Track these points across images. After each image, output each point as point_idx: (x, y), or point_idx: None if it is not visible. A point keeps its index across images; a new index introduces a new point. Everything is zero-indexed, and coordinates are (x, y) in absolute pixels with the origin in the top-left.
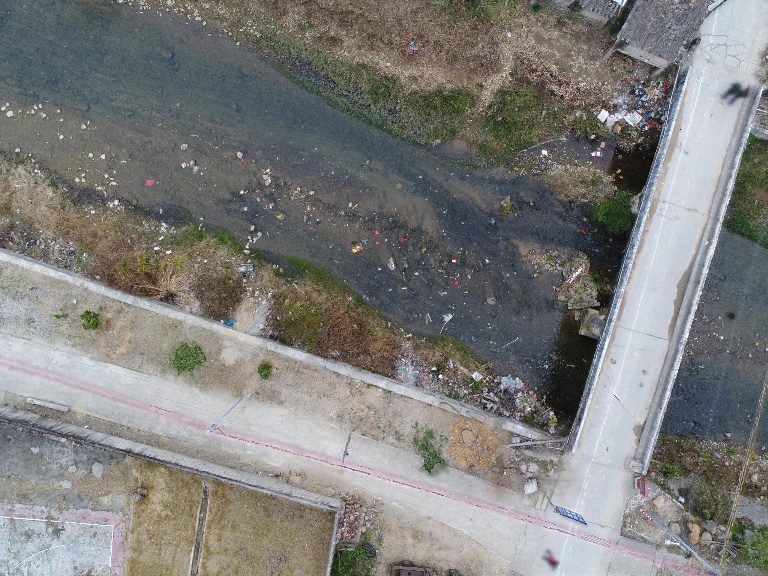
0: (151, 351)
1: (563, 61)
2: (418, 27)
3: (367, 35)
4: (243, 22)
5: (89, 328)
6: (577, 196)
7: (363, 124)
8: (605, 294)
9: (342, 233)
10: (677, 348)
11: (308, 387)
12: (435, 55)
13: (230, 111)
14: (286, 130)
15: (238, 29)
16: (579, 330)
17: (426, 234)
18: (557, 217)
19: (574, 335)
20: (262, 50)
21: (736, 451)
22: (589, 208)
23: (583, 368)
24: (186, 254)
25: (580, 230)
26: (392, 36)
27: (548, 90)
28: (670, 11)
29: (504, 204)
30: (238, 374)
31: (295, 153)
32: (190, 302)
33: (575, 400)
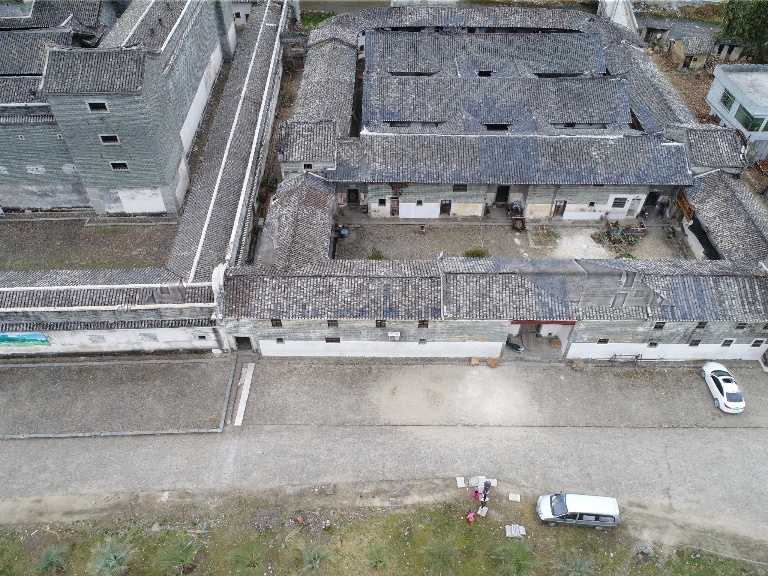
0: None
1: None
2: None
3: None
4: None
5: None
6: None
7: None
8: None
9: None
10: None
11: None
12: None
13: None
14: None
15: None
16: None
17: None
18: None
19: None
20: None
21: (553, 4)
22: None
23: None
24: None
25: None
26: None
27: None
28: None
29: None
30: None
31: None
32: None
33: None
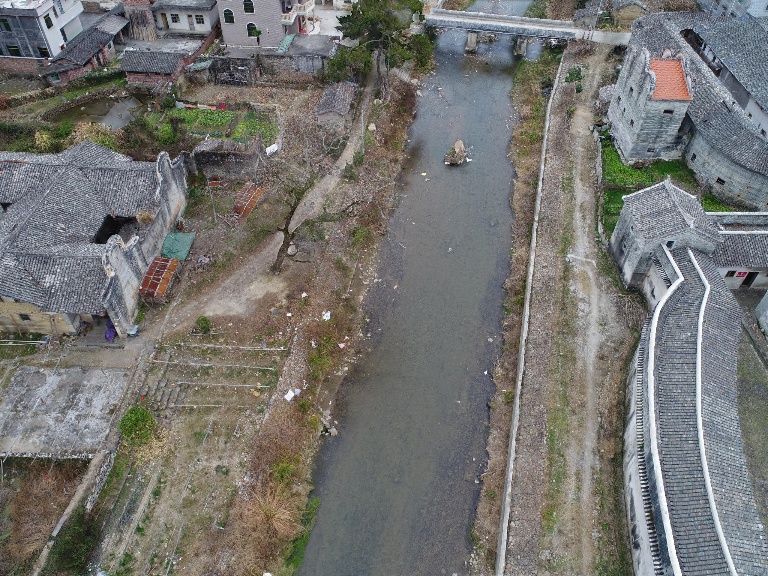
0: None
1: None
2: None
3: None
4: None
5: None
6: None
7: None
8: None
9: (488, 6)
10: None
11: None
12: None
13: None
14: None
15: None
16: None
17: None
18: None
19: None
20: None
21: (432, 65)
22: None
23: None
24: None
25: None
26: None
27: None
28: None
29: None
30: None
31: (511, 1)
32: None
33: None
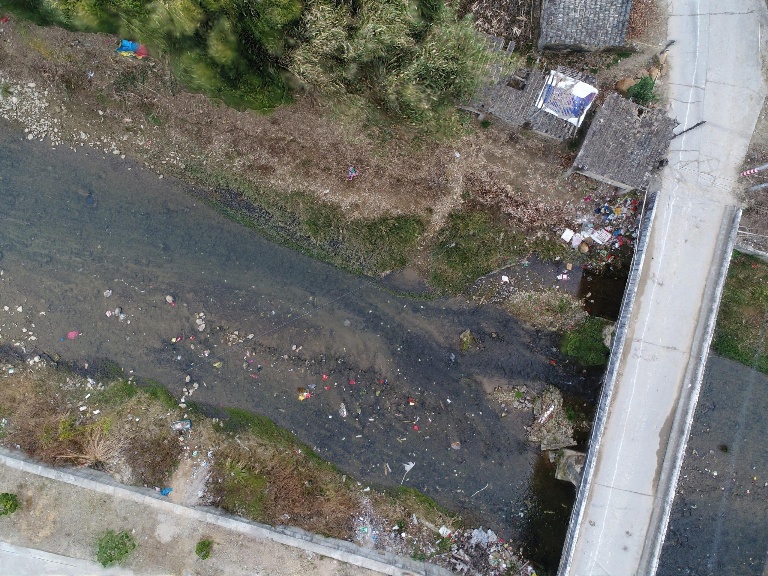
0: (78, 531)
1: (519, 181)
2: (356, 151)
3: (301, 161)
4: (165, 153)
5: (5, 514)
6: (544, 324)
7: (303, 257)
8: (582, 431)
9: (287, 379)
10: (663, 507)
11: (254, 563)
12: (377, 180)
13: (157, 250)
14: (219, 268)
15: (160, 161)
16: (555, 473)
17: (380, 375)
18: (523, 348)
19: (550, 478)
20: (188, 182)
21: None
22: (558, 337)
23: (562, 514)
24: (115, 413)
25: (550, 362)
26: (329, 161)
27: (504, 213)
28: (631, 135)
29: (464, 338)
30: (176, 552)
31: (231, 293)
32: (121, 469)
33: (555, 550)
